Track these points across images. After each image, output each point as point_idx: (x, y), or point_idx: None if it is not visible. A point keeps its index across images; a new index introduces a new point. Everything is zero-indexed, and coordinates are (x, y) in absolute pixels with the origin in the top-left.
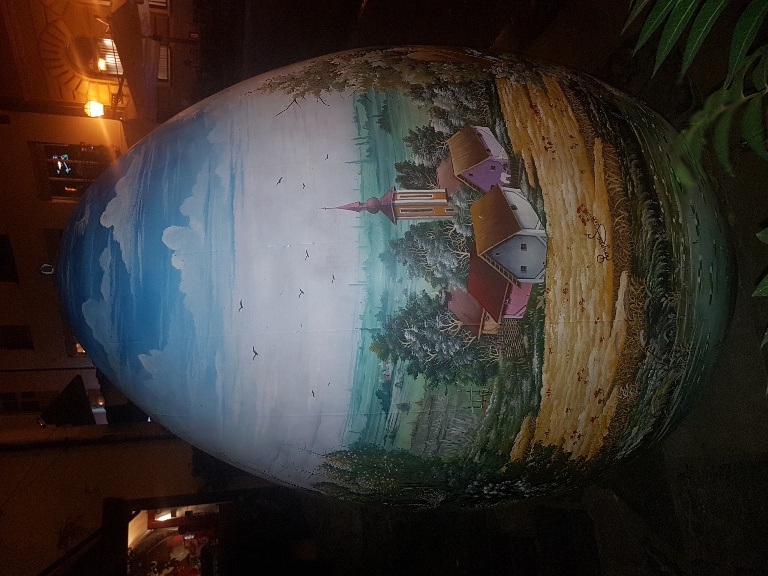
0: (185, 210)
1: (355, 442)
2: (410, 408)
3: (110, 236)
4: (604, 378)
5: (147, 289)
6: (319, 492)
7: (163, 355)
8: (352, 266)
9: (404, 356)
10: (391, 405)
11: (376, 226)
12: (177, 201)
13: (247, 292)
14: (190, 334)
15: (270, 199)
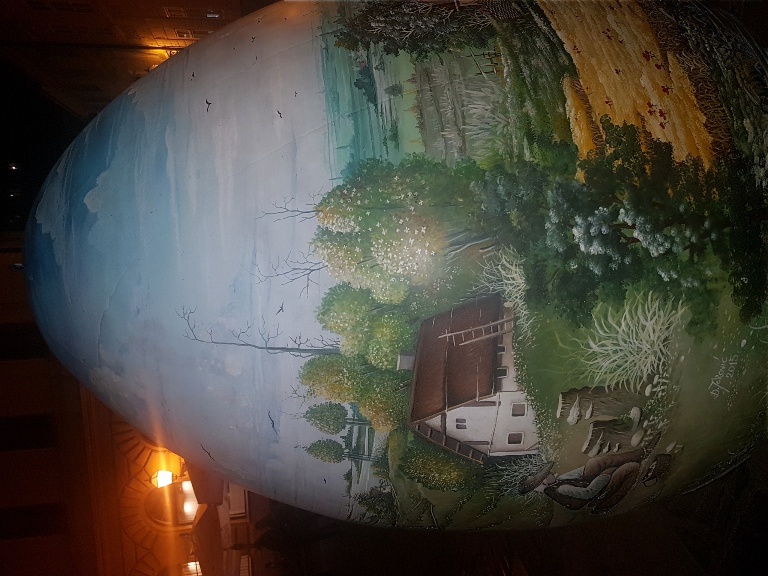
0: None
1: (348, 164)
2: (403, 89)
3: None
4: (644, 41)
5: (101, 127)
6: (336, 350)
7: (110, 174)
8: (303, 8)
9: (376, 40)
10: (378, 92)
11: None
12: None
13: (200, 66)
14: (139, 129)
15: None
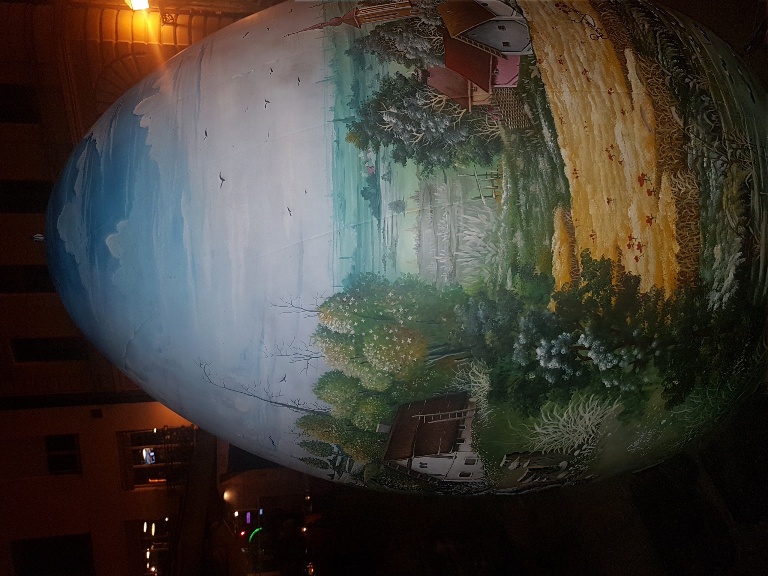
0: (157, 85)
1: (349, 275)
2: (405, 207)
3: (89, 141)
4: (644, 160)
5: (116, 160)
6: (328, 413)
7: (129, 225)
8: (318, 67)
9: (386, 141)
10: (382, 206)
11: (340, 33)
12: (151, 84)
13: (212, 121)
14: (155, 185)
15: (236, 48)
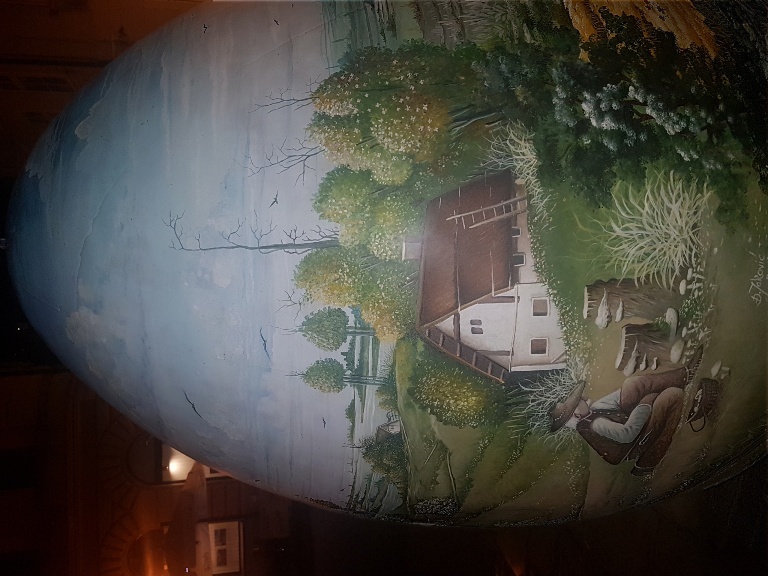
0: None
1: (345, 54)
2: None
3: None
4: None
5: None
6: (335, 242)
7: (103, 102)
8: None
9: None
10: None
11: None
12: None
13: None
14: (136, 61)
15: None
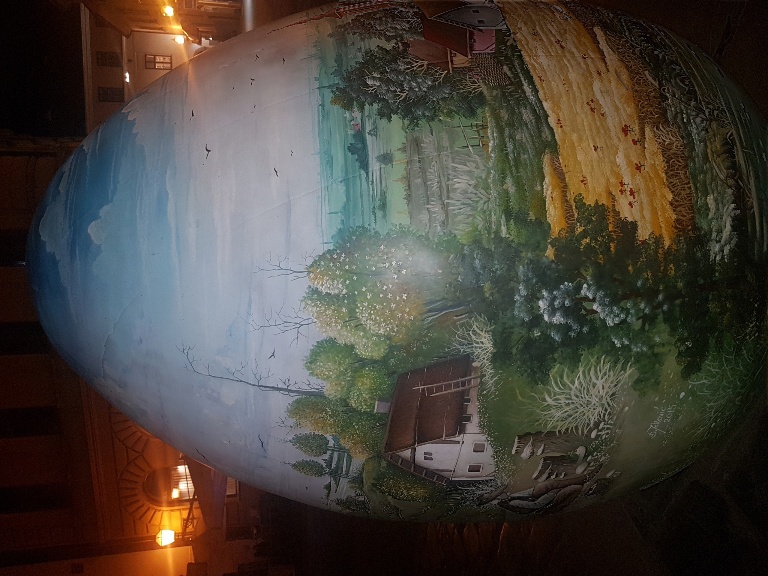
0: None
1: (338, 230)
2: (393, 158)
3: None
4: (625, 113)
5: (102, 153)
6: (321, 393)
7: (112, 208)
8: (302, 48)
9: (371, 101)
10: (369, 160)
11: (322, 23)
12: (140, 90)
13: (199, 103)
14: (140, 165)
15: None
